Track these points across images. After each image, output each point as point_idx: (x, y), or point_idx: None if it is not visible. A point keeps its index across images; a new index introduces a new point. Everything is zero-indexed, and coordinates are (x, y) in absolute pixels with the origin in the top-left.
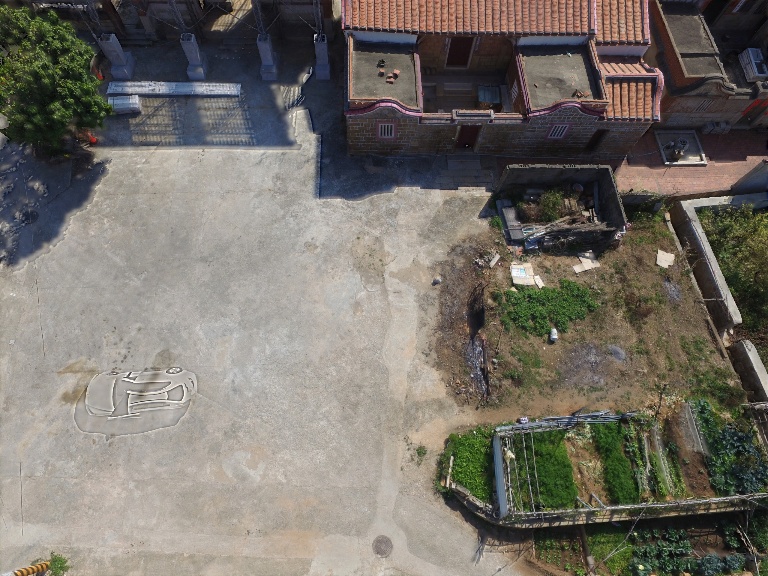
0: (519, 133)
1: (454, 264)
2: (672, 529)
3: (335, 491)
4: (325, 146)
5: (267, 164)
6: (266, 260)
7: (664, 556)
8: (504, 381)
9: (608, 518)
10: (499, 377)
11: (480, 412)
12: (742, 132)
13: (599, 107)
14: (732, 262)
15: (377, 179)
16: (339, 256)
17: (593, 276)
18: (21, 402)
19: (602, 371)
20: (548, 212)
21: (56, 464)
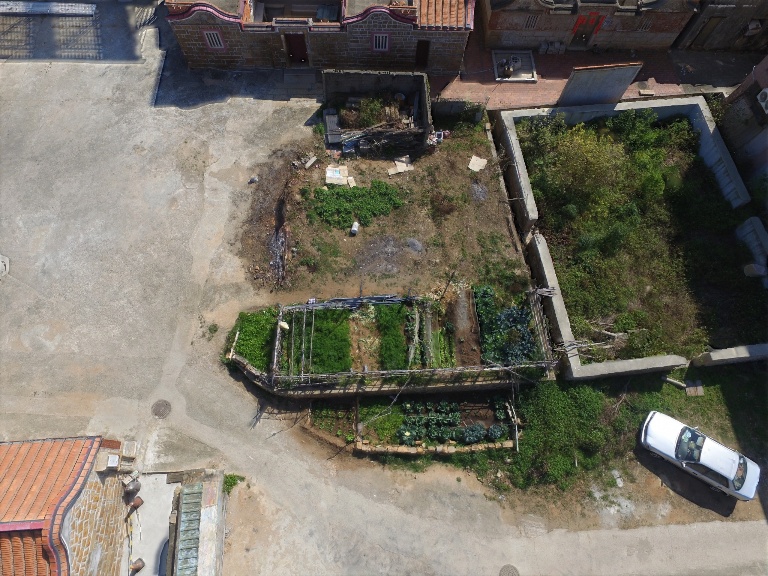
0: (344, 44)
1: (273, 166)
2: (444, 402)
3: (124, 361)
4: (168, 61)
5: (110, 76)
6: (94, 160)
7: (431, 424)
8: (300, 267)
9: (378, 387)
10: (296, 264)
11: (274, 295)
12: (579, 53)
13: (410, 14)
14: (551, 171)
15: (213, 90)
16: (164, 158)
17: (405, 178)
18: None
19: (396, 260)
20: (365, 117)
21: None
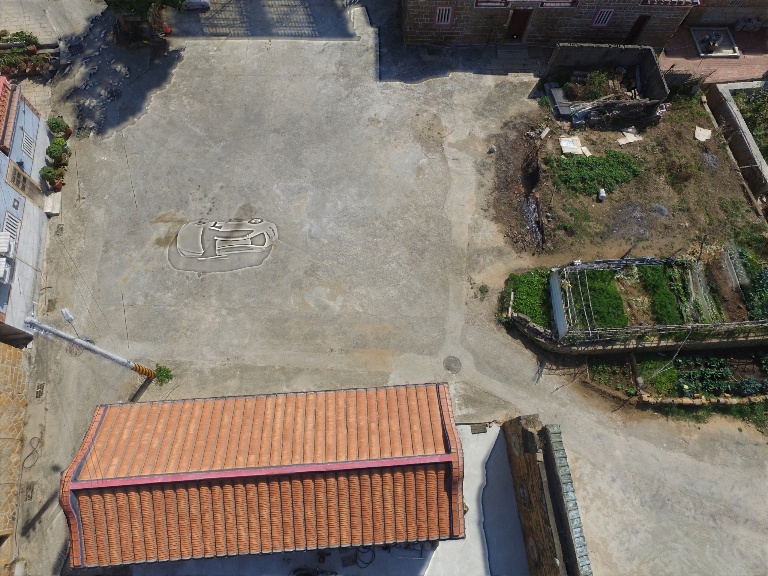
0: (566, 19)
1: (507, 136)
2: (713, 358)
3: (407, 319)
4: (382, 38)
5: (329, 52)
6: (334, 132)
7: (706, 378)
8: (558, 231)
9: (656, 343)
10: (553, 228)
11: (536, 257)
12: None
13: None
14: (764, 142)
15: (432, 66)
16: (401, 129)
17: (636, 148)
18: (119, 246)
19: (647, 225)
20: (594, 89)
21: (155, 295)
